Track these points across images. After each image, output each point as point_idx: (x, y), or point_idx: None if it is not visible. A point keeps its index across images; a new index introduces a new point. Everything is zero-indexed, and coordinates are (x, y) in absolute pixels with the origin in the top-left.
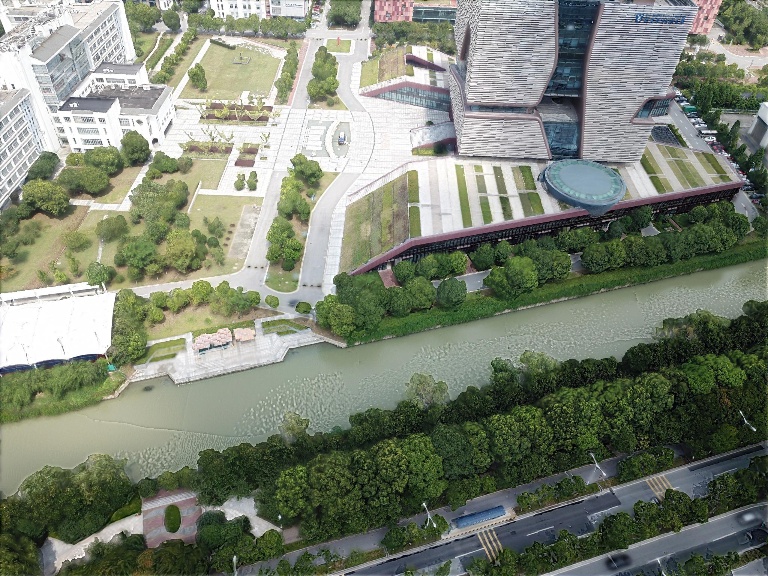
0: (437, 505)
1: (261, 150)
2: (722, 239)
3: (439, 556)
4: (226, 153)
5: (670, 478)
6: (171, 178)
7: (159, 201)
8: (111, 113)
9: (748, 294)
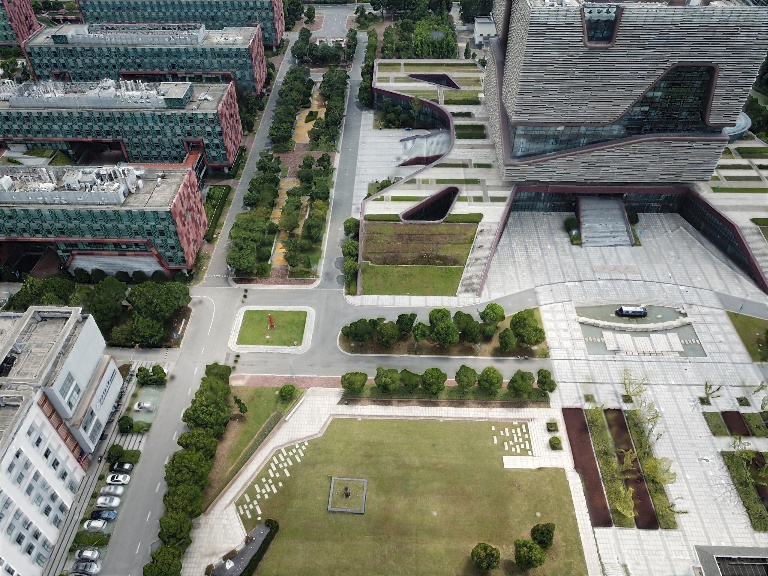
0: None
1: None
2: None
3: None
4: (763, 457)
5: None
6: None
7: None
8: None
9: None
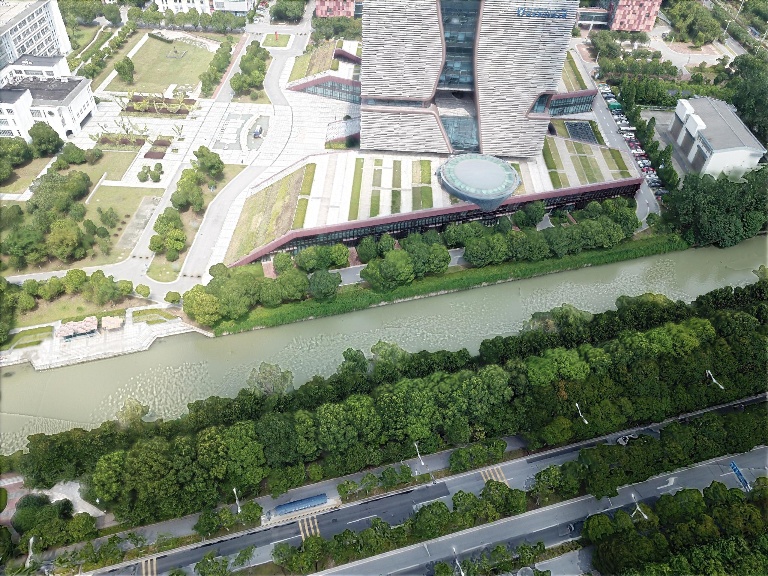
0: (263, 492)
1: (171, 142)
2: (609, 234)
3: (254, 542)
4: (138, 145)
5: (505, 470)
6: (78, 169)
7: (58, 191)
8: (20, 104)
9: (634, 290)
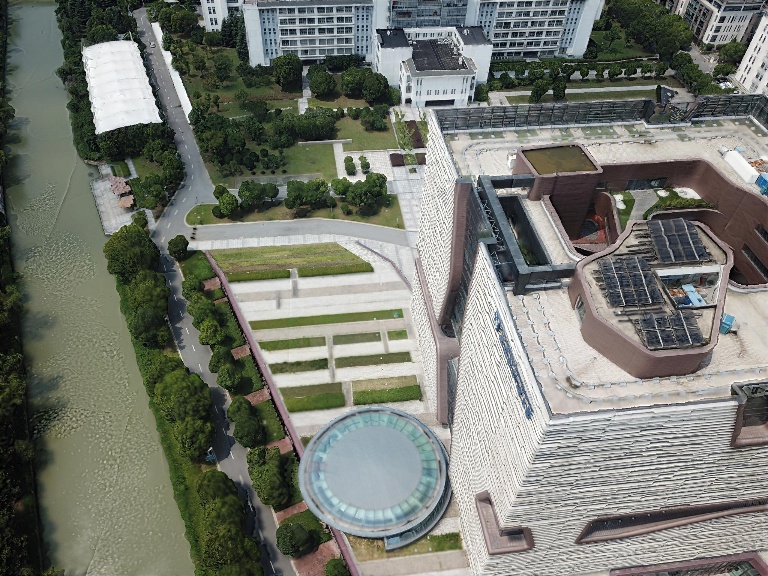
0: None
1: None
2: None
3: None
4: (411, 145)
5: None
6: (355, 125)
7: None
8: (391, 53)
9: None
